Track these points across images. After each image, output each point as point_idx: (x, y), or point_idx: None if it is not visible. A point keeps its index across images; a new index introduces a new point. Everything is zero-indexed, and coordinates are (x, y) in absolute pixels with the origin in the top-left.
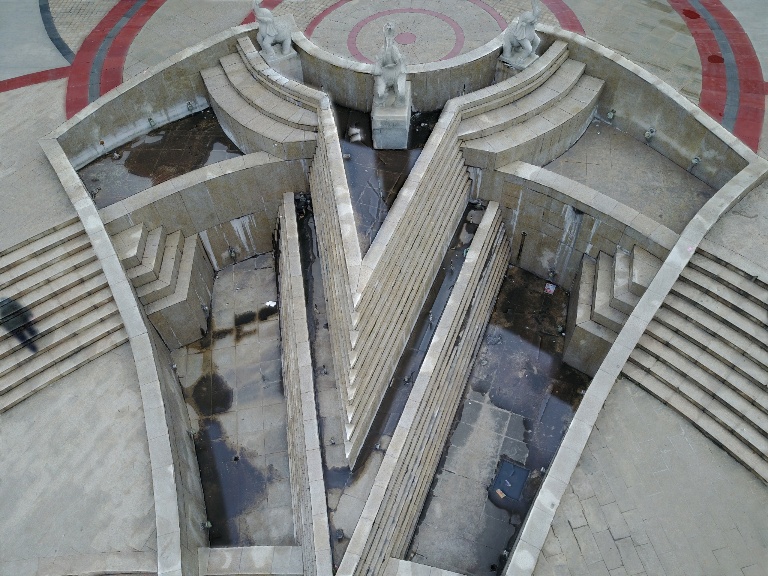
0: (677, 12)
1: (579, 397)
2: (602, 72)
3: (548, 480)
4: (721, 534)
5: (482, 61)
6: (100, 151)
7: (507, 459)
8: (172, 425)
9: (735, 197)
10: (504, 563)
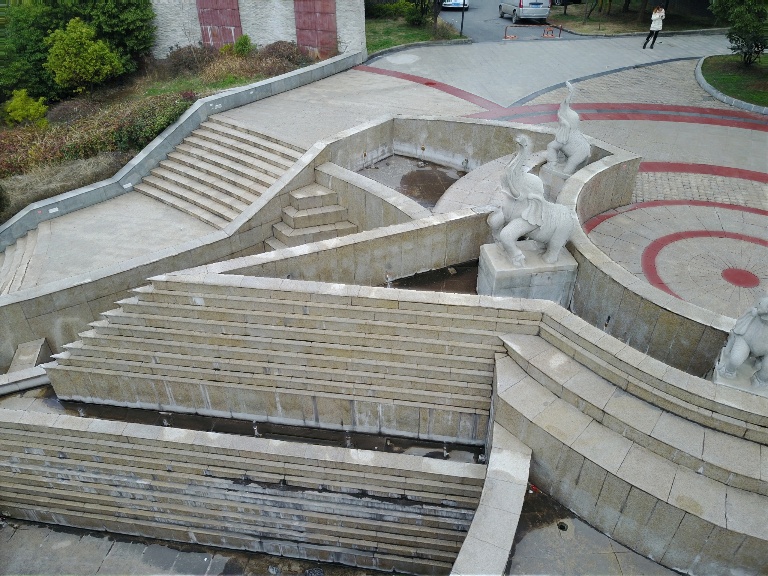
0: None
1: None
2: None
3: None
4: None
5: (682, 323)
6: (419, 154)
7: None
8: None
9: None
10: None
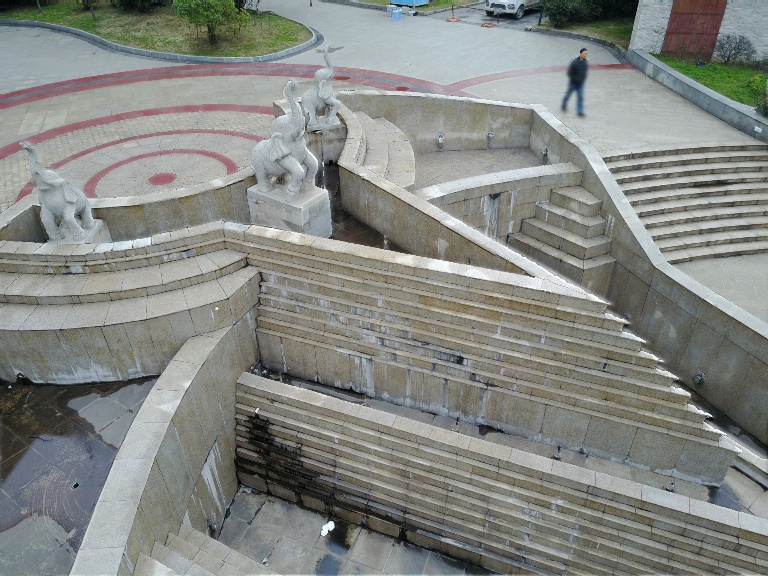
0: (332, 80)
1: None
2: (378, 111)
3: None
4: None
5: None
6: None
7: None
8: None
9: None
10: None
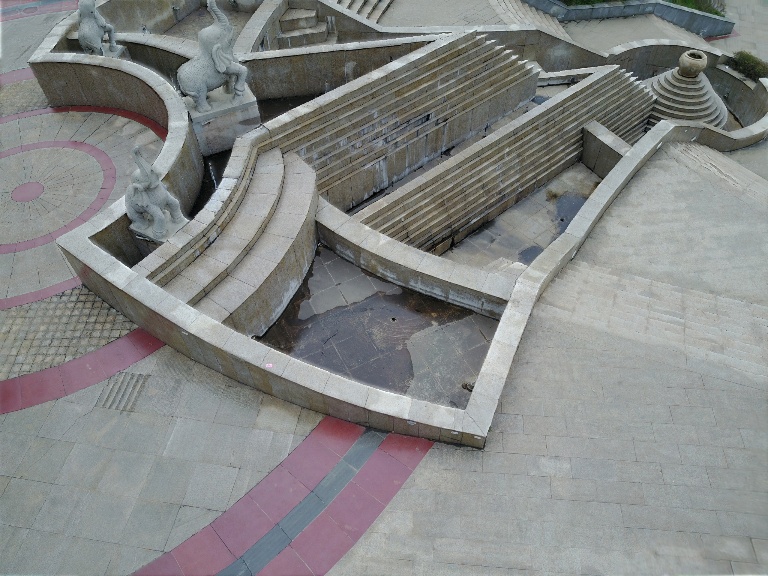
0: None
1: None
2: None
3: None
4: None
5: None
6: None
7: None
8: None
9: None
10: None
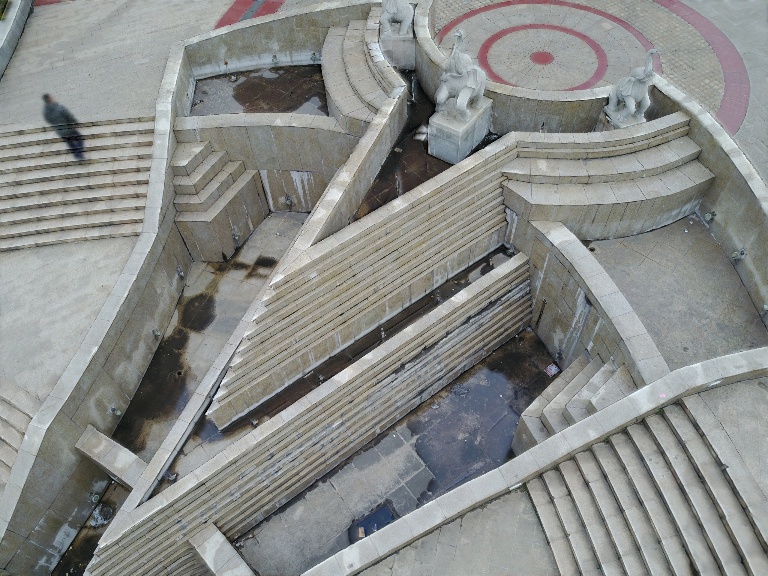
0: None
1: None
2: (715, 164)
3: (365, 540)
4: None
5: (579, 105)
6: (223, 70)
7: (390, 506)
8: (129, 317)
9: (765, 366)
10: None
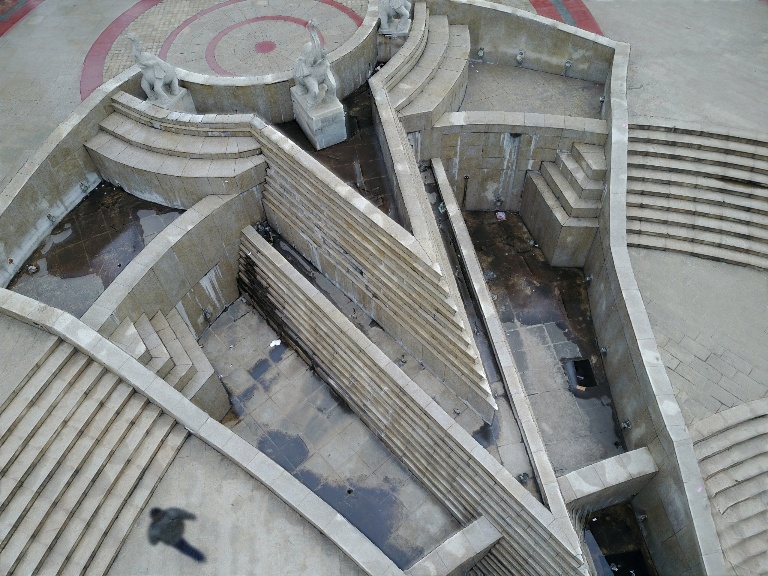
0: None
1: (581, 286)
2: (463, 18)
3: (640, 343)
4: (761, 318)
5: (369, 39)
6: (11, 271)
7: (566, 360)
8: None
9: (625, 76)
10: (622, 436)
